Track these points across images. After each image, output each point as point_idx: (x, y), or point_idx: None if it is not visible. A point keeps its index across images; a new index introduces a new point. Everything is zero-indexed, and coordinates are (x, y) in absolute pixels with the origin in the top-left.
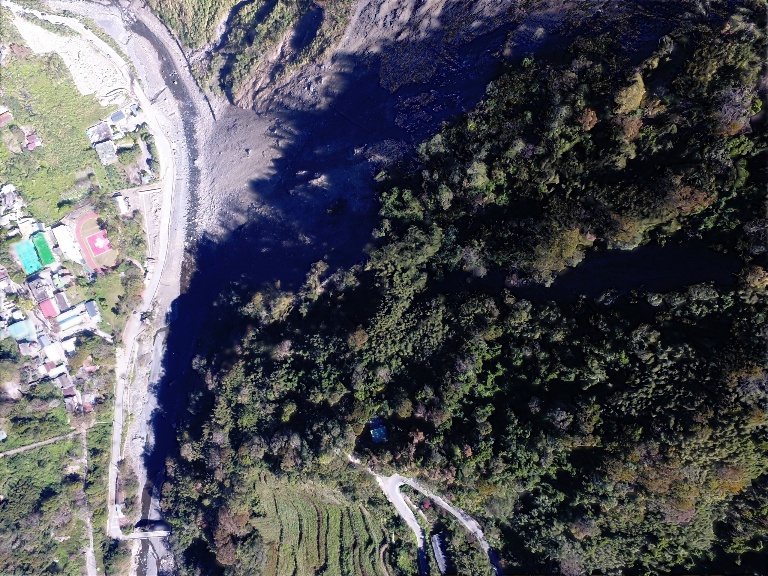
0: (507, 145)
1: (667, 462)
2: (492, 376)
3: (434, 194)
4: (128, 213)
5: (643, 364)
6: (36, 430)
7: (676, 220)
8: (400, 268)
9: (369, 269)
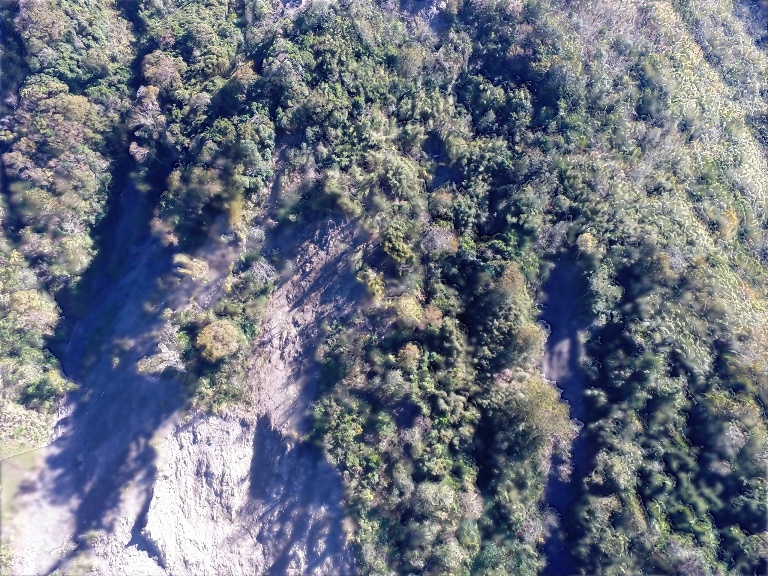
0: (407, 449)
1: (759, 333)
2: (697, 519)
3: (441, 571)
4: None
5: (665, 339)
6: None
7: (529, 290)
8: None
9: None
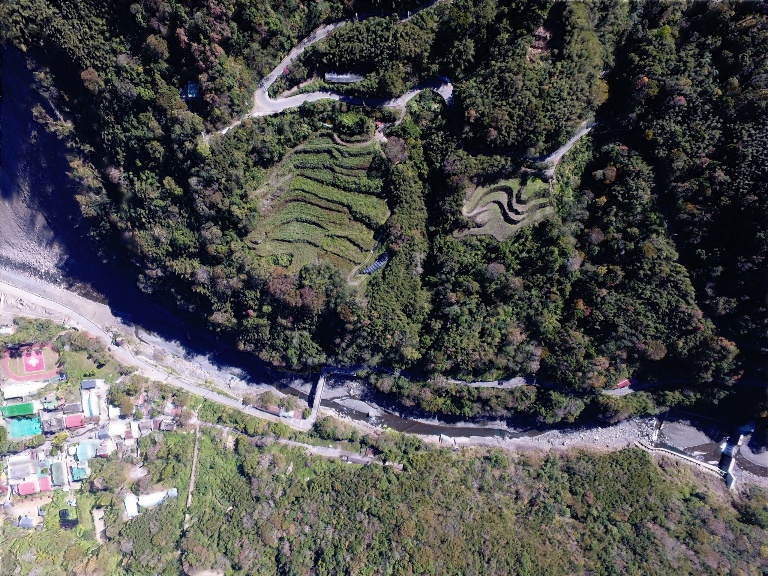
0: None
1: None
2: None
3: None
4: (14, 329)
5: None
6: (180, 461)
7: None
8: (16, 5)
9: (25, 47)
